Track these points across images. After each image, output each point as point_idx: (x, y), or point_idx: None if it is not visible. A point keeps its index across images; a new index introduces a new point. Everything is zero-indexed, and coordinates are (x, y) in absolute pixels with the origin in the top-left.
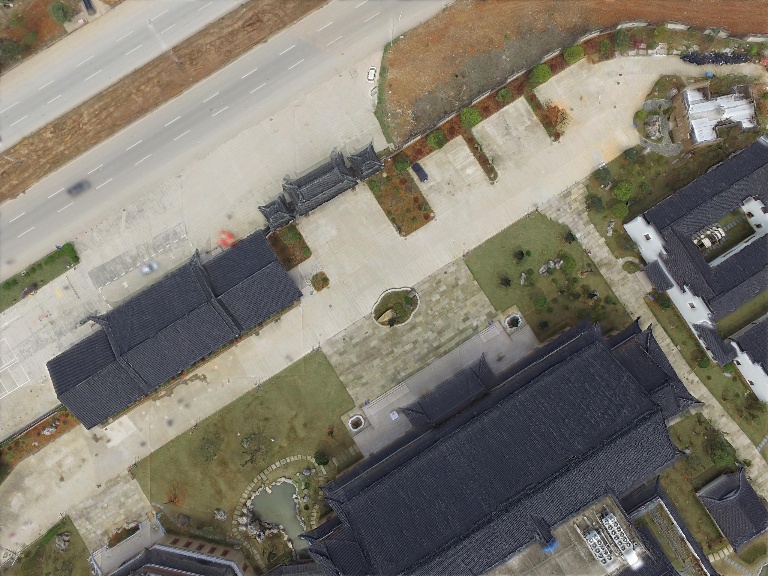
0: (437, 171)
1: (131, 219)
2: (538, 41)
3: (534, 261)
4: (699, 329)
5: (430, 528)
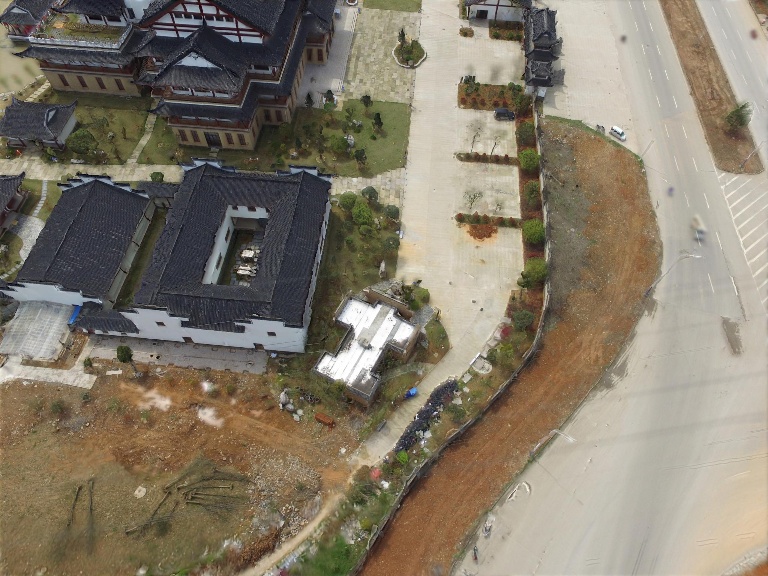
0: (497, 128)
1: None
2: None
3: (364, 138)
4: None
5: None
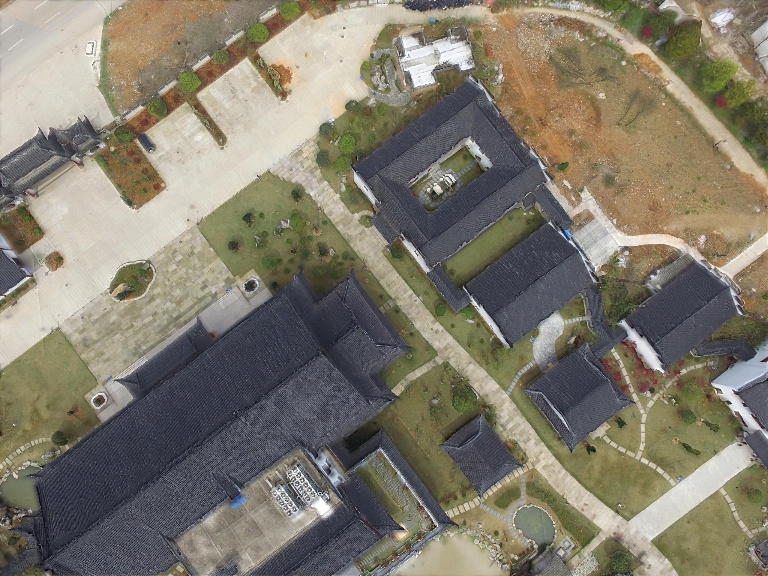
0: (165, 140)
1: None
2: (260, 1)
3: (268, 223)
4: (431, 277)
5: (105, 494)
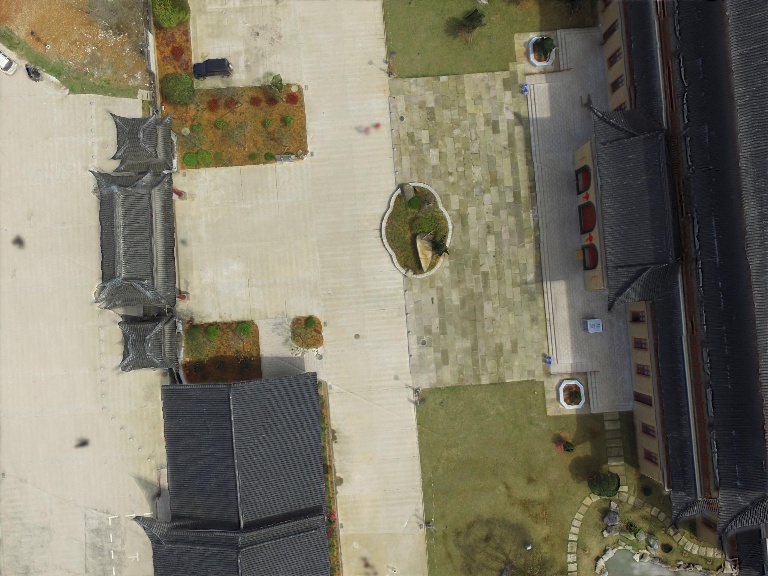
0: (226, 42)
1: None
2: None
3: None
4: None
5: None
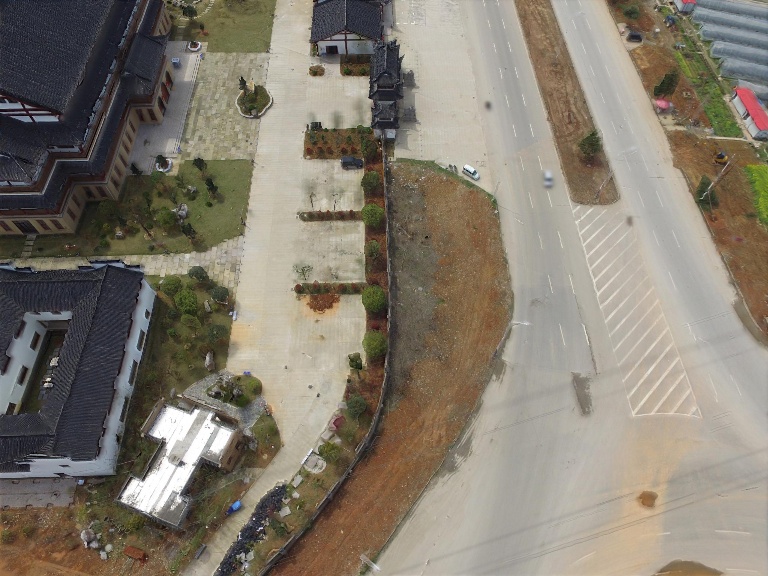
0: (344, 179)
1: (448, 5)
2: None
3: (199, 206)
4: None
5: None
